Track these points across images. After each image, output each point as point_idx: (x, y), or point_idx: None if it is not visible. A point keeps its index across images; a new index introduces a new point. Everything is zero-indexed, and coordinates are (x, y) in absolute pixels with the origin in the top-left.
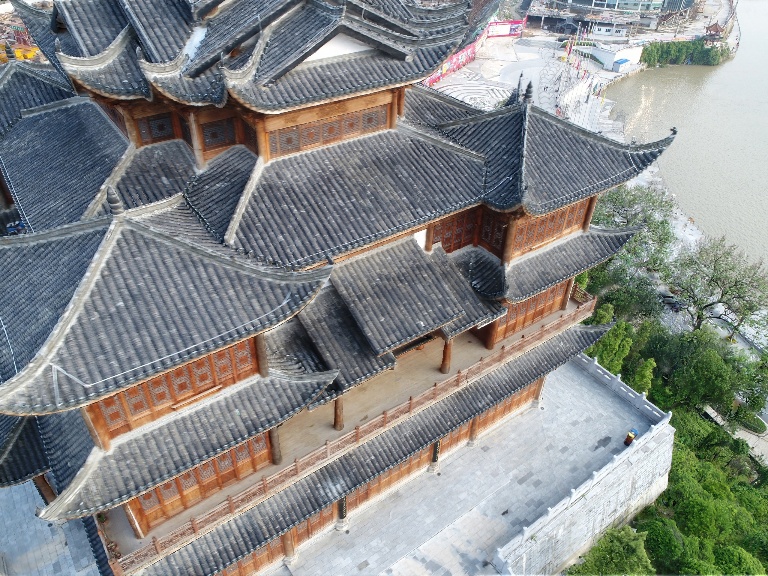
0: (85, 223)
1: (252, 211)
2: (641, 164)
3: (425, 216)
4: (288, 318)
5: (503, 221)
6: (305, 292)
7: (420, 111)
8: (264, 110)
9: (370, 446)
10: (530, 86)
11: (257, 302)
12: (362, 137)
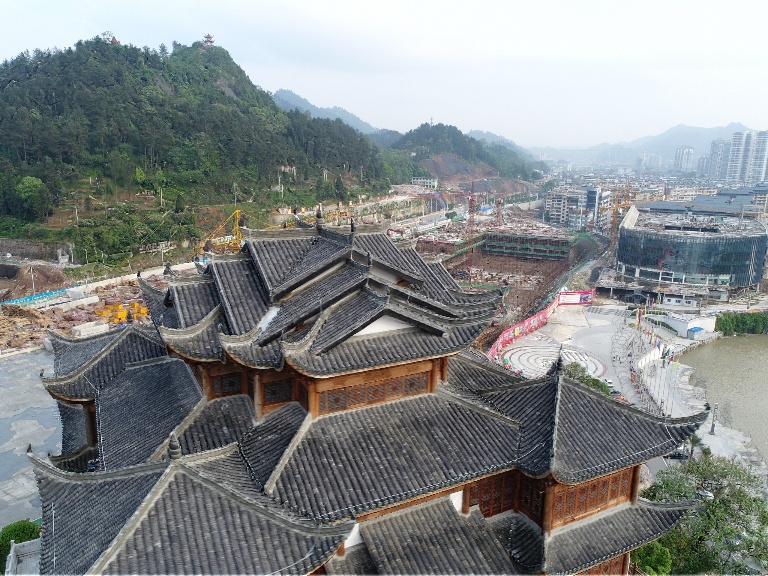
0: (147, 465)
1: (294, 463)
2: (679, 437)
3: (457, 477)
4: (309, 573)
5: (540, 487)
6: (328, 546)
7: (463, 377)
8: (314, 375)
9: None
10: (561, 360)
11: (282, 553)
12: (404, 399)
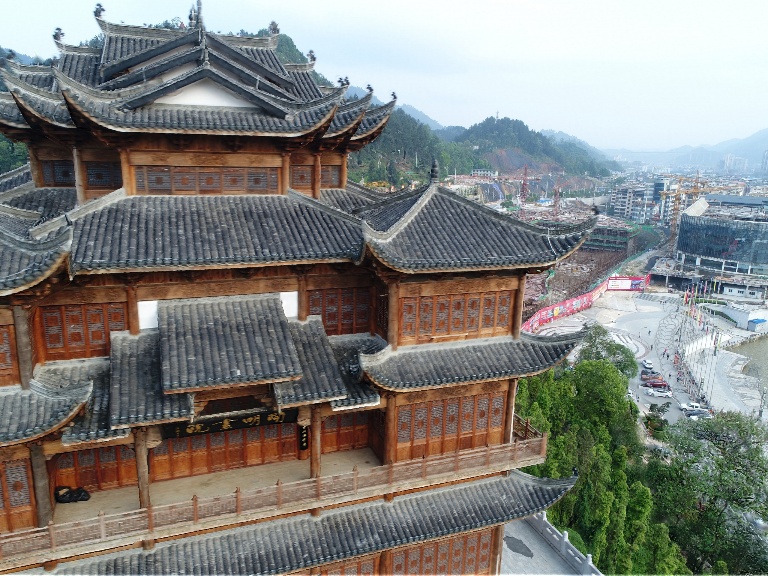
0: None
1: (82, 223)
2: (561, 248)
3: None
4: (22, 288)
5: None
6: None
7: (344, 204)
8: (106, 124)
9: (187, 557)
10: (434, 165)
11: None
12: (246, 196)
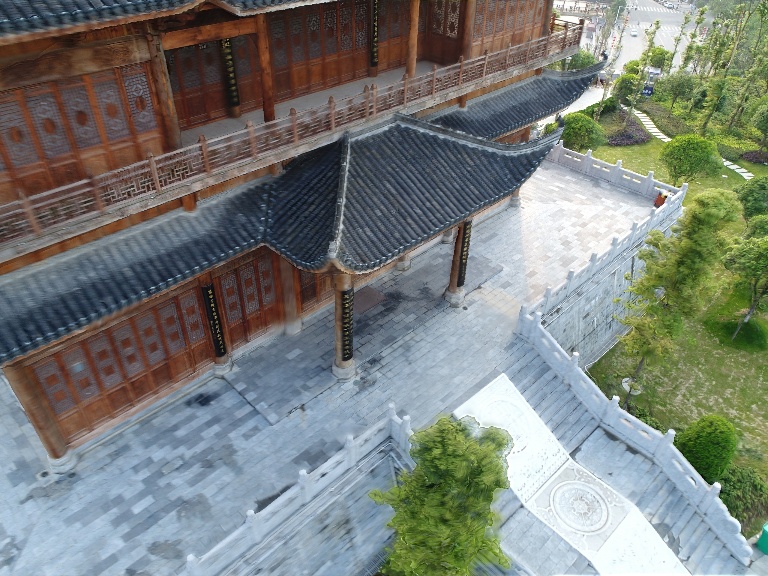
0: None
1: None
2: None
3: None
4: None
5: None
6: None
7: None
8: None
9: None
10: None
11: None
12: None
